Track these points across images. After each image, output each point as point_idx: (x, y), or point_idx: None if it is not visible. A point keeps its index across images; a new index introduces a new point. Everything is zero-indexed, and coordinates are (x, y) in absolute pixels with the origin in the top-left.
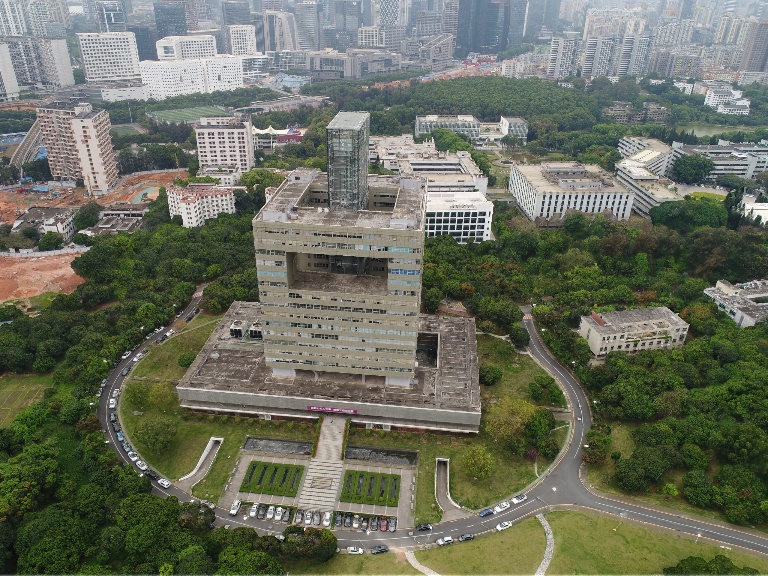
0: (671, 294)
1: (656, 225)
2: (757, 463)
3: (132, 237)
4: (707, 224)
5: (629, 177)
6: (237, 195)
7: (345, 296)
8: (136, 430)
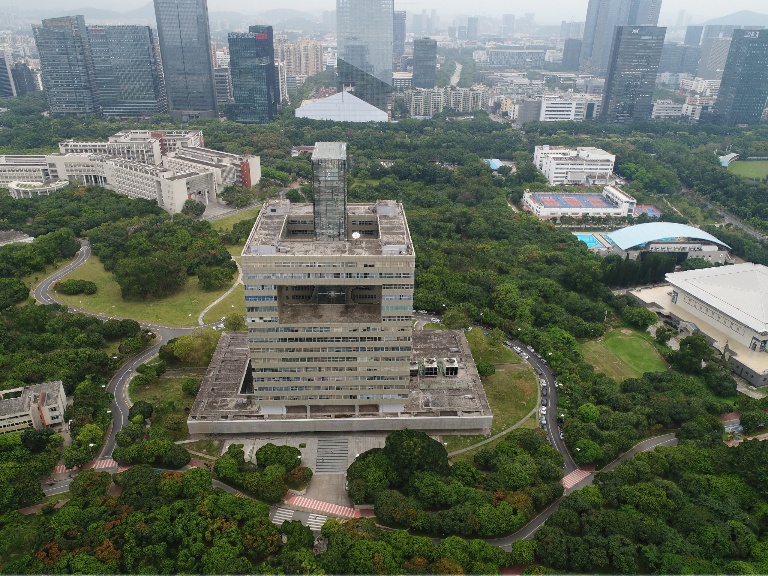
0: None
1: None
2: None
3: None
4: None
5: None
6: None
7: None
8: None
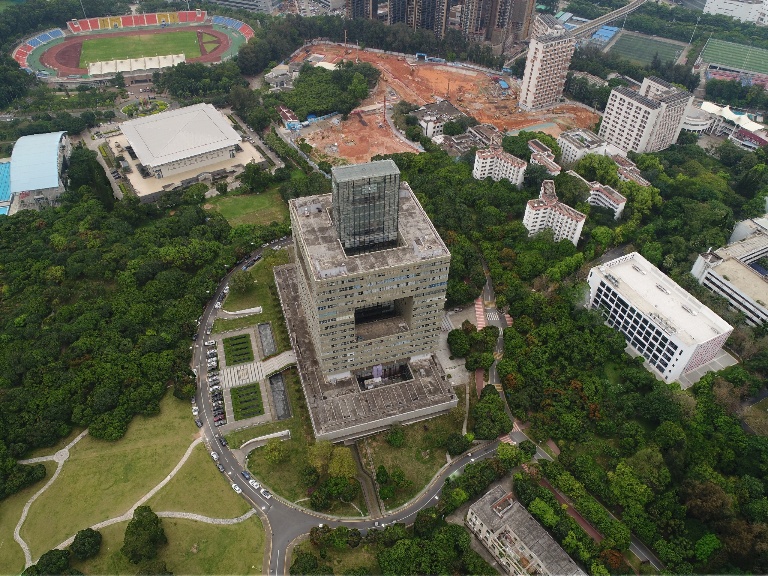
0: None
1: None
2: None
3: (433, 160)
4: None
5: None
6: (529, 171)
7: None
8: None
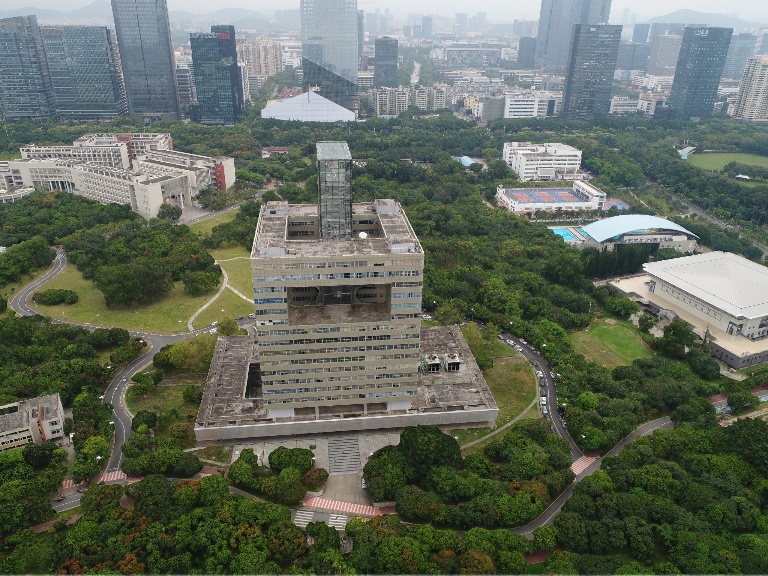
0: None
1: None
2: None
3: None
4: None
5: None
6: None
7: None
8: None
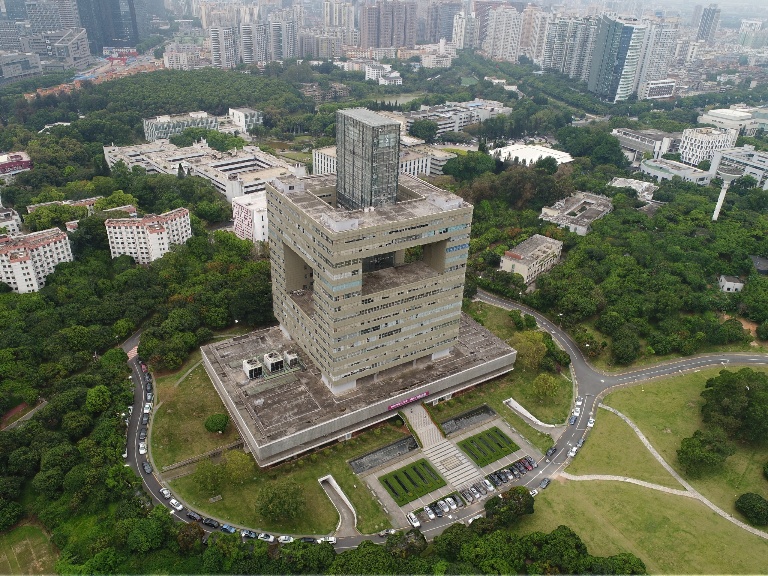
0: (524, 225)
1: (472, 177)
2: (675, 313)
3: None
4: (487, 170)
5: (403, 145)
6: None
7: (410, 286)
8: (259, 508)
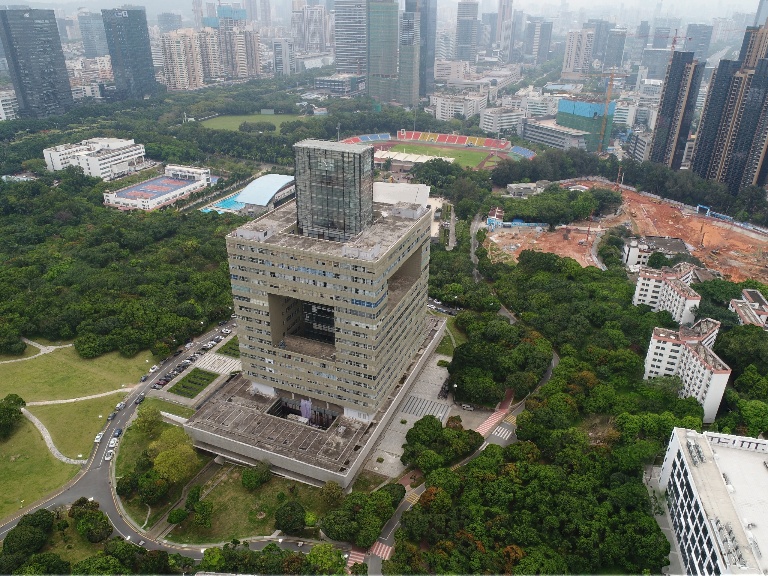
0: None
1: None
2: None
3: (595, 273)
4: None
5: None
6: (702, 309)
7: None
8: None
